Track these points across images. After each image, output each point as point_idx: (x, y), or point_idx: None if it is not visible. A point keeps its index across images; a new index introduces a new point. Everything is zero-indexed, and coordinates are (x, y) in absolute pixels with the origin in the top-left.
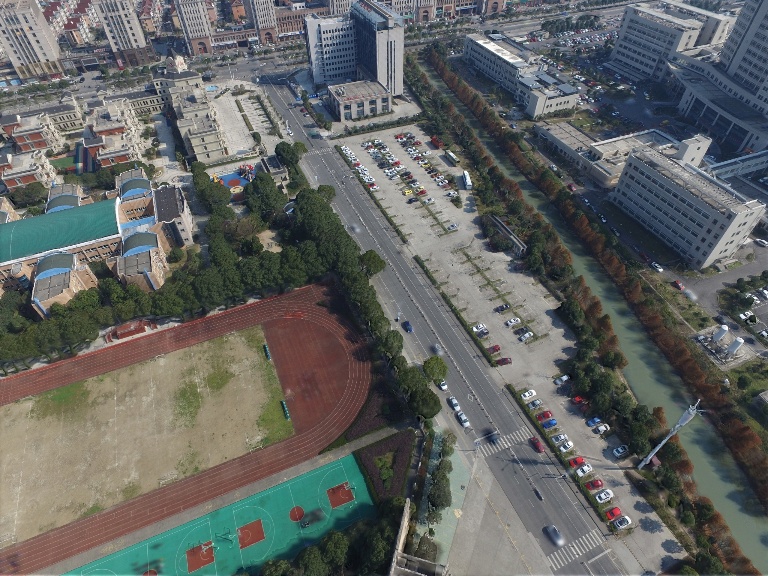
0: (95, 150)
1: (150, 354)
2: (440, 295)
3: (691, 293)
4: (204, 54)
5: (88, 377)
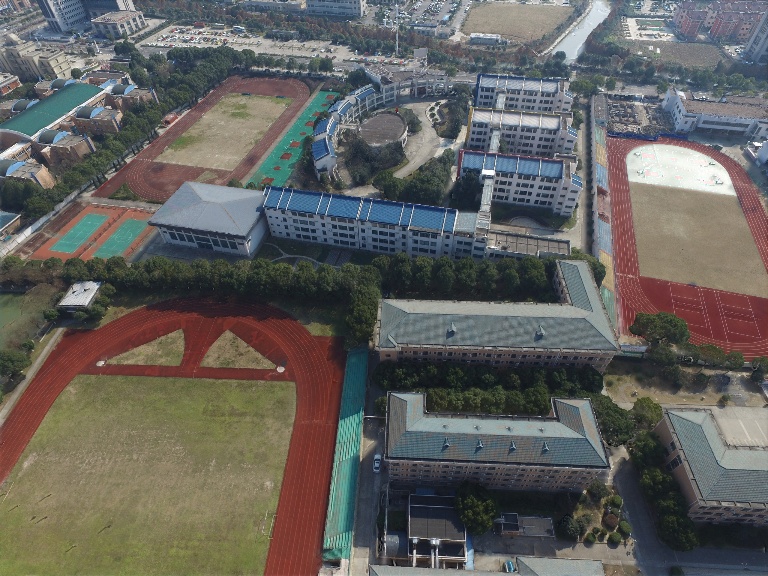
0: None
1: (196, 119)
2: (287, 57)
3: (366, 22)
4: None
5: (180, 135)
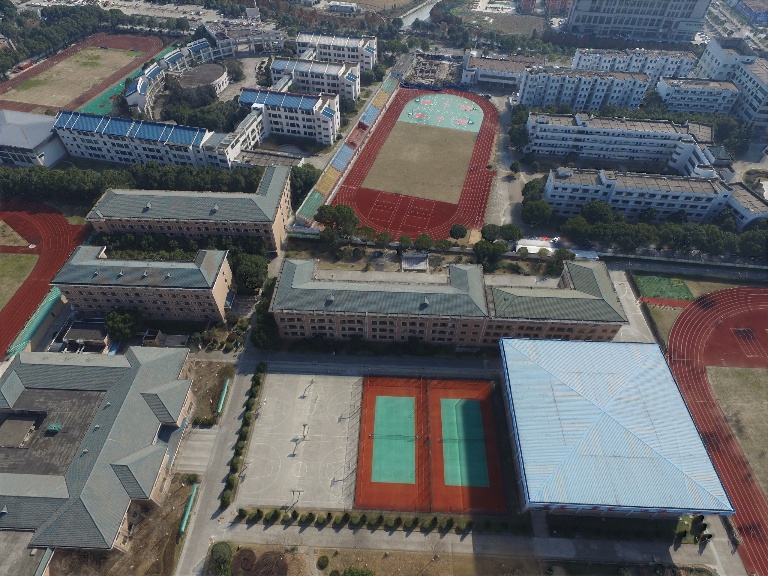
0: None
1: (49, 66)
2: (157, 18)
3: None
4: None
5: (29, 79)
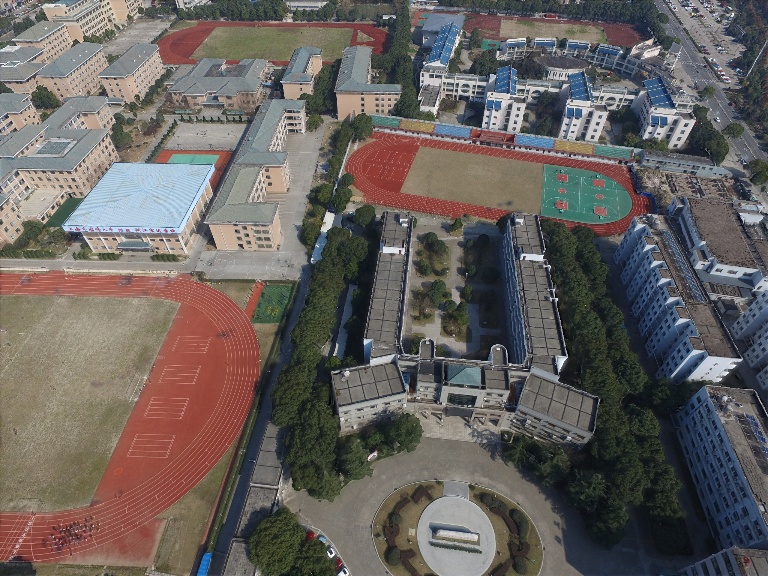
0: None
1: (557, 22)
2: (689, 37)
3: None
4: None
5: (534, 21)
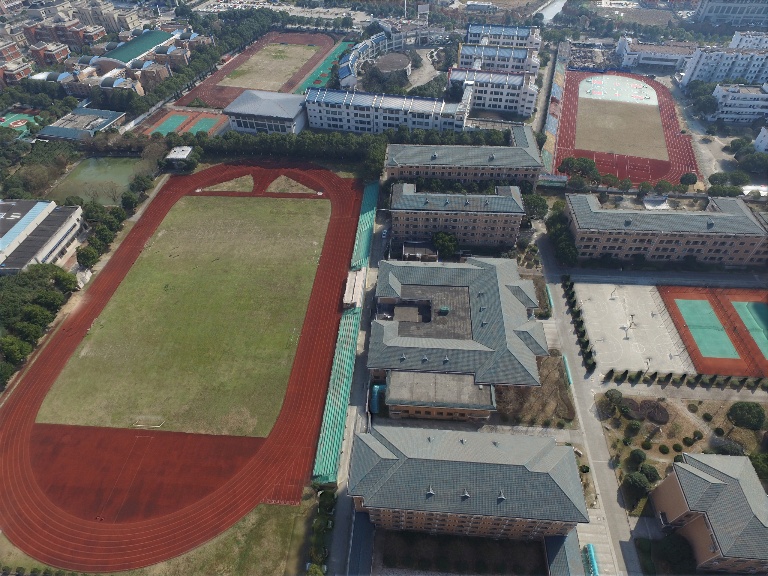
0: (82, 33)
1: (245, 59)
2: (315, 19)
3: None
4: (3, 15)
5: (234, 69)
